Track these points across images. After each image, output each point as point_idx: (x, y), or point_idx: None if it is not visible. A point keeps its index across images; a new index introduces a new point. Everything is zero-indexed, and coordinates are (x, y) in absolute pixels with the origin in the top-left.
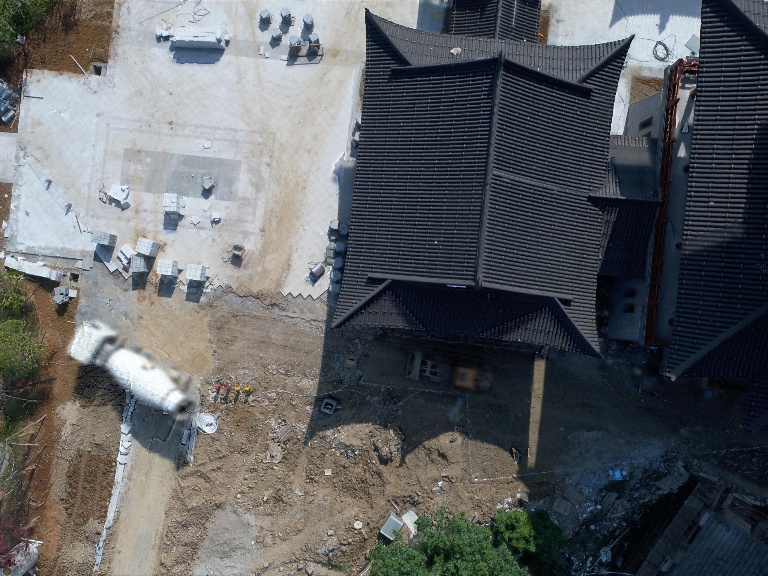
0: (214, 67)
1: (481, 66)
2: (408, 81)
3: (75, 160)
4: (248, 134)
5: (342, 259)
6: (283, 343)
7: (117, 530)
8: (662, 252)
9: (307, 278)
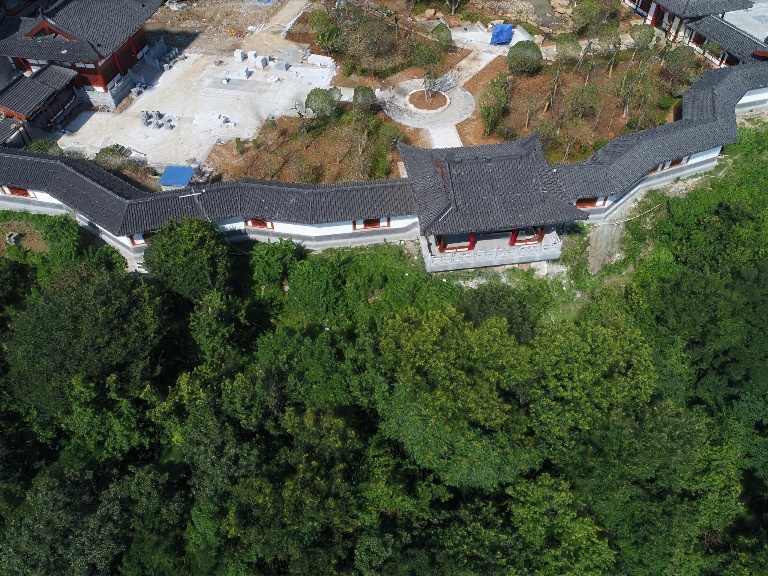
0: None
1: None
2: None
3: None
4: None
5: None
6: None
7: None
8: (17, 5)
9: None
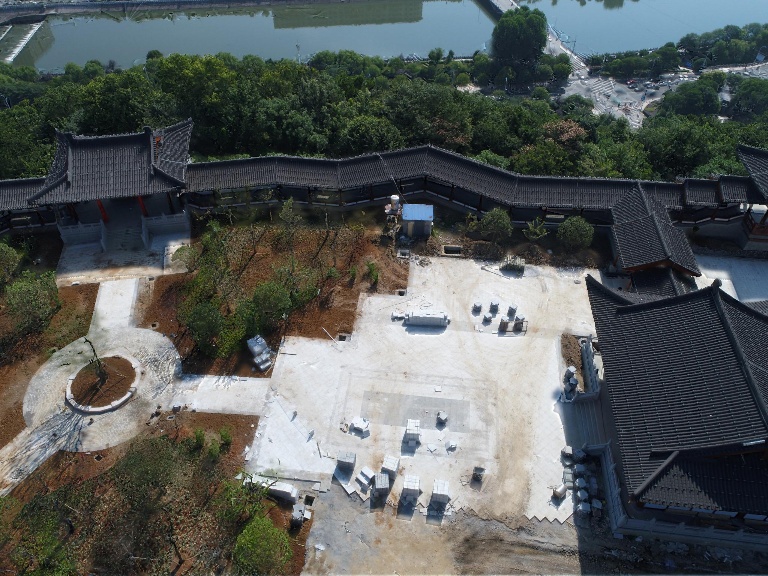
0: (439, 337)
1: (697, 296)
2: (633, 315)
3: (320, 399)
4: (473, 382)
5: (584, 480)
6: (536, 571)
7: None
8: None
9: (549, 502)
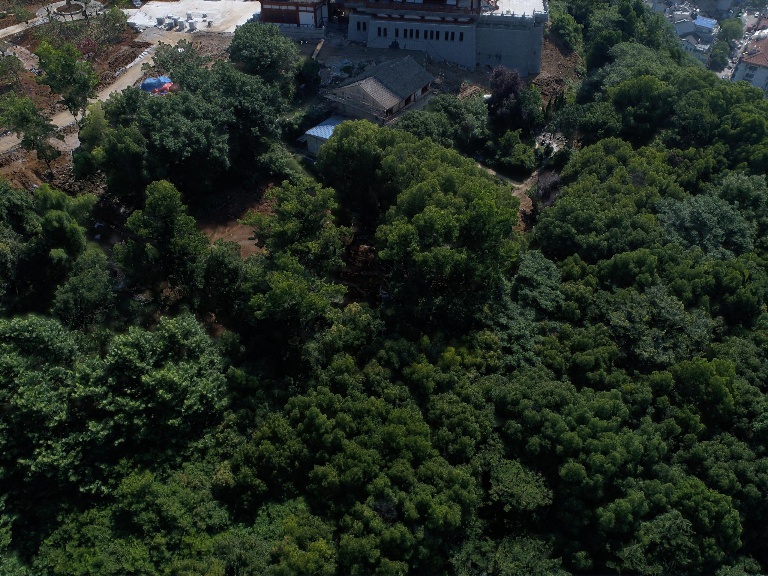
0: None
1: None
2: None
3: None
4: (224, 10)
5: None
6: None
7: (129, 70)
8: None
9: None
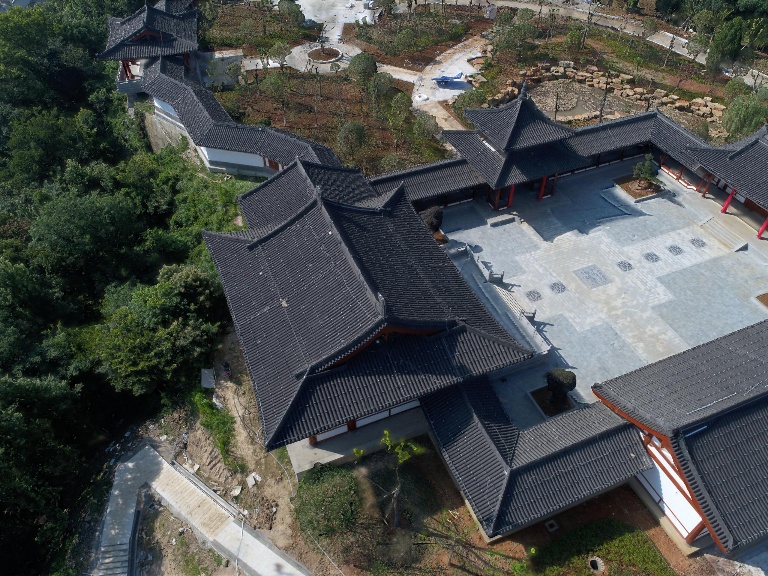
0: None
1: None
2: None
3: None
4: None
5: None
6: None
7: None
8: None
9: None
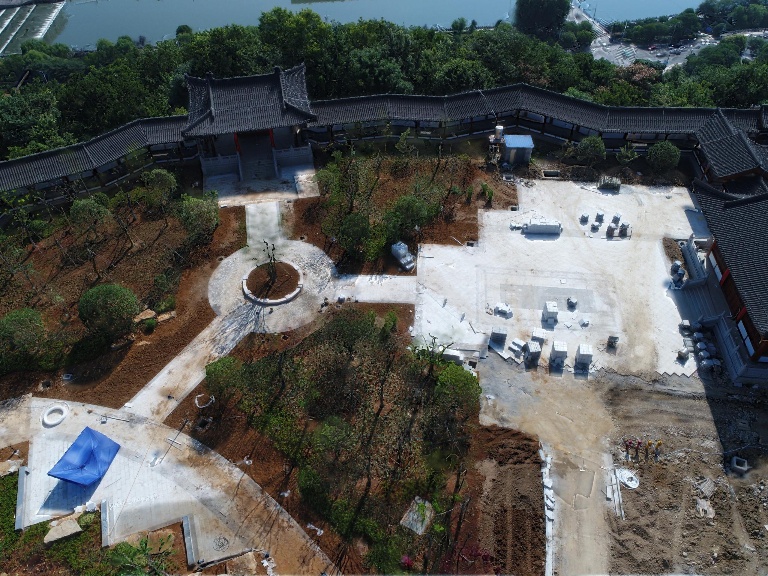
0: (555, 242)
1: None
2: (740, 208)
3: (463, 290)
4: (592, 275)
5: None
6: (674, 410)
7: None
8: None
9: (675, 362)
